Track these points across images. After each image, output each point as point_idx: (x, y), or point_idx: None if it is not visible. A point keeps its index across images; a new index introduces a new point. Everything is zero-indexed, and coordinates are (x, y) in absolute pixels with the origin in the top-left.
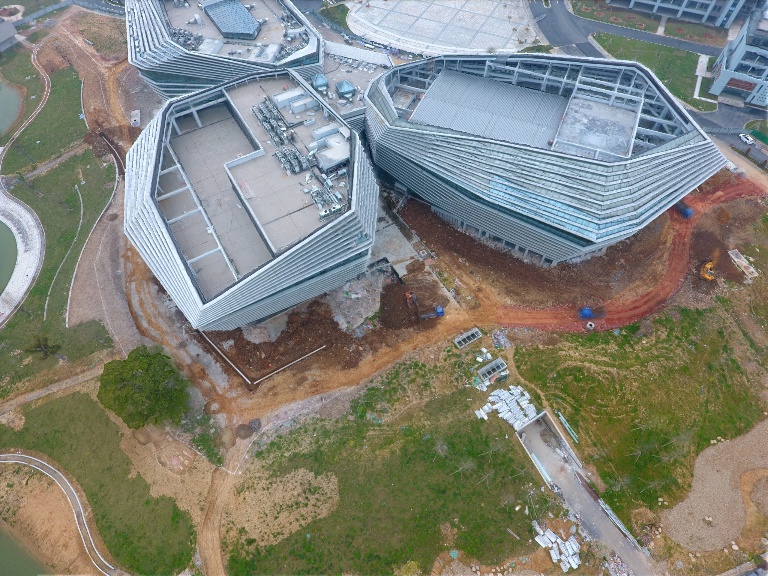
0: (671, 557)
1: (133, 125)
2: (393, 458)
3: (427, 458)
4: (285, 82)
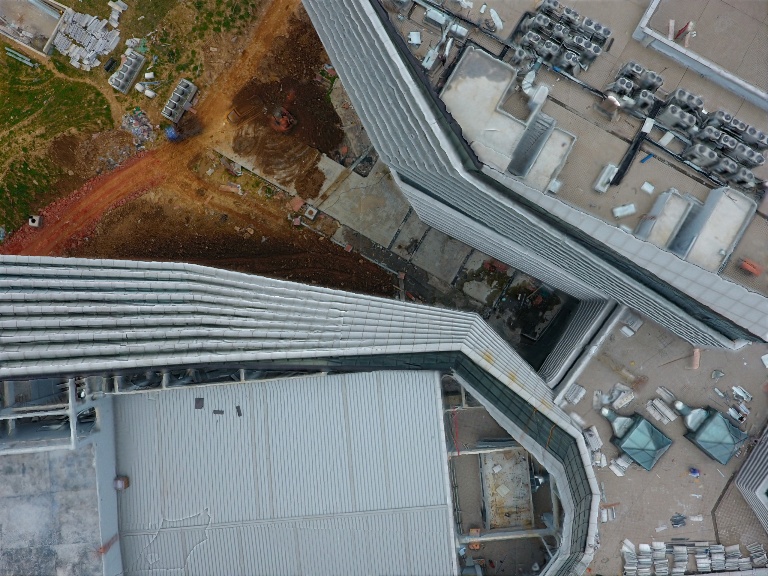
0: None
1: None
2: None
3: None
4: None
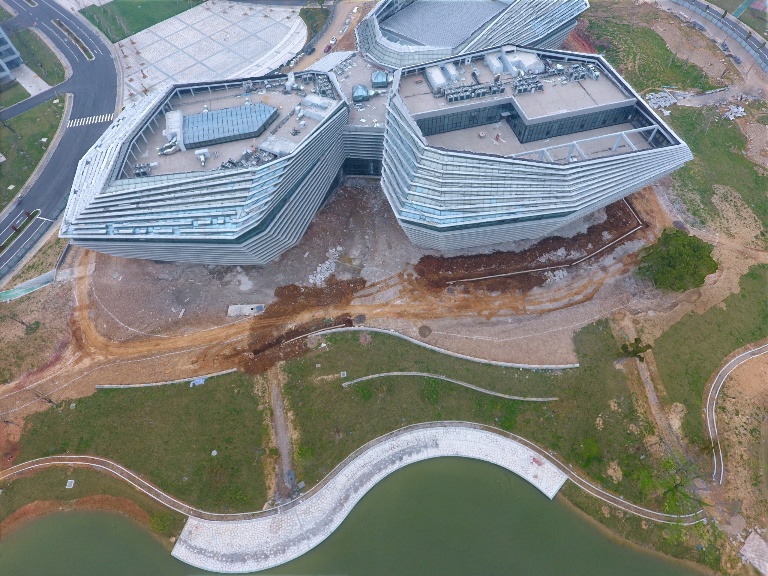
0: (732, 79)
1: (261, 312)
2: (699, 156)
3: (698, 142)
4: (405, 82)
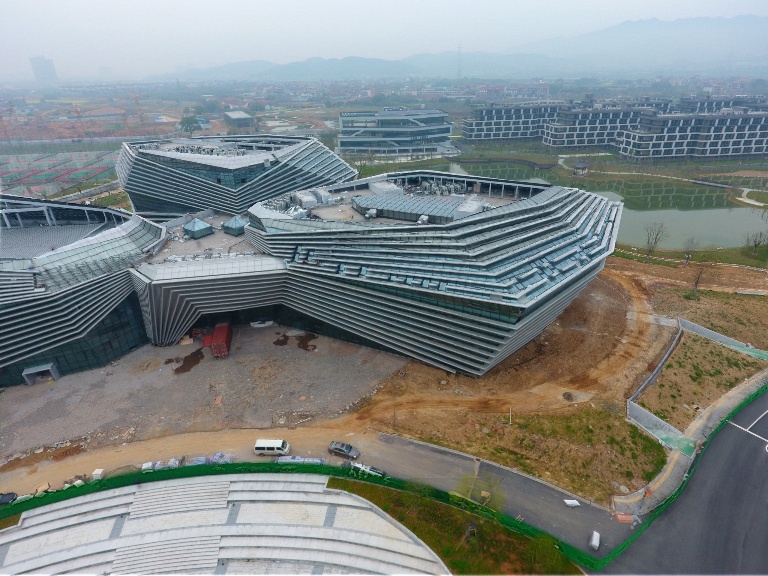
0: None
1: None
2: None
3: None
4: None
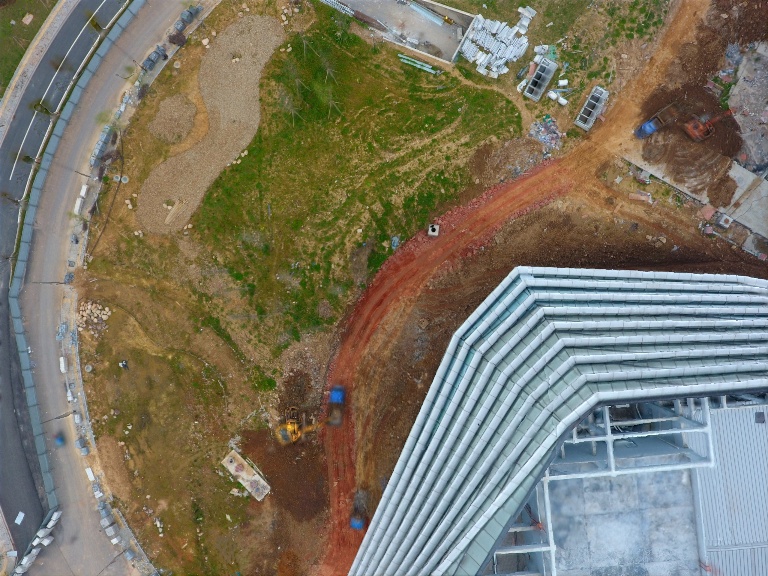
0: None
1: None
2: None
3: None
4: None
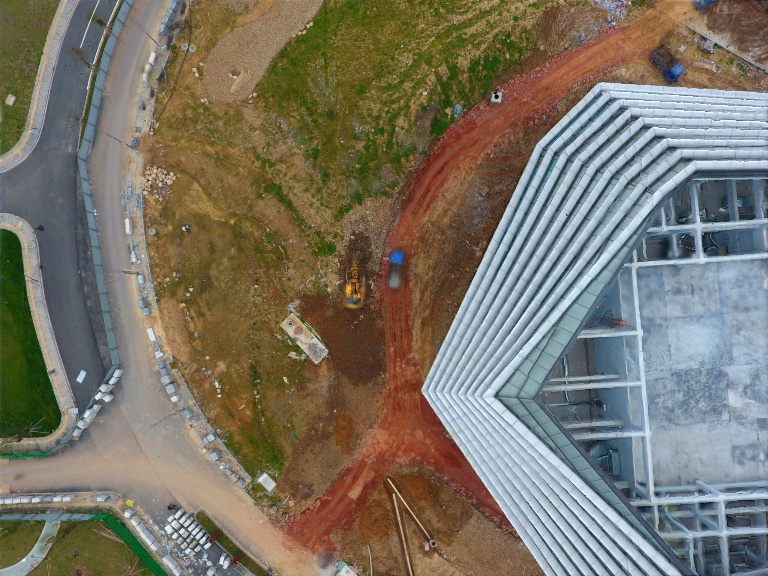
0: None
1: None
2: None
3: None
4: None
